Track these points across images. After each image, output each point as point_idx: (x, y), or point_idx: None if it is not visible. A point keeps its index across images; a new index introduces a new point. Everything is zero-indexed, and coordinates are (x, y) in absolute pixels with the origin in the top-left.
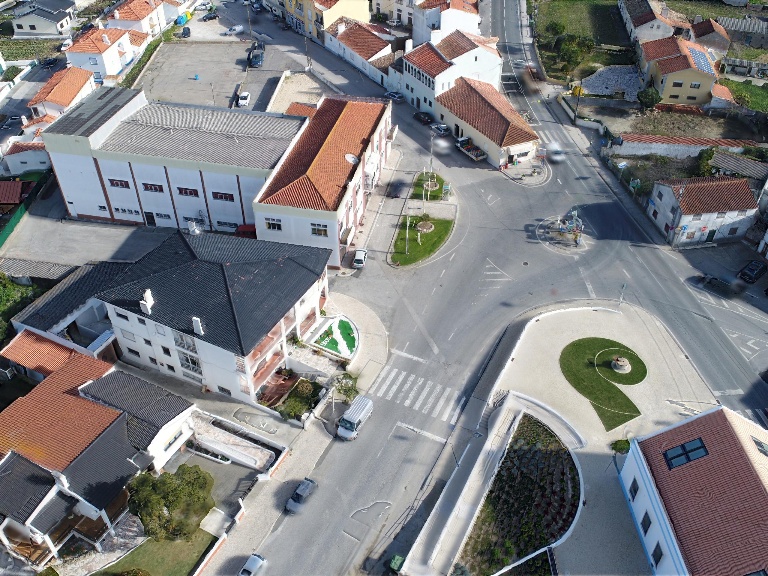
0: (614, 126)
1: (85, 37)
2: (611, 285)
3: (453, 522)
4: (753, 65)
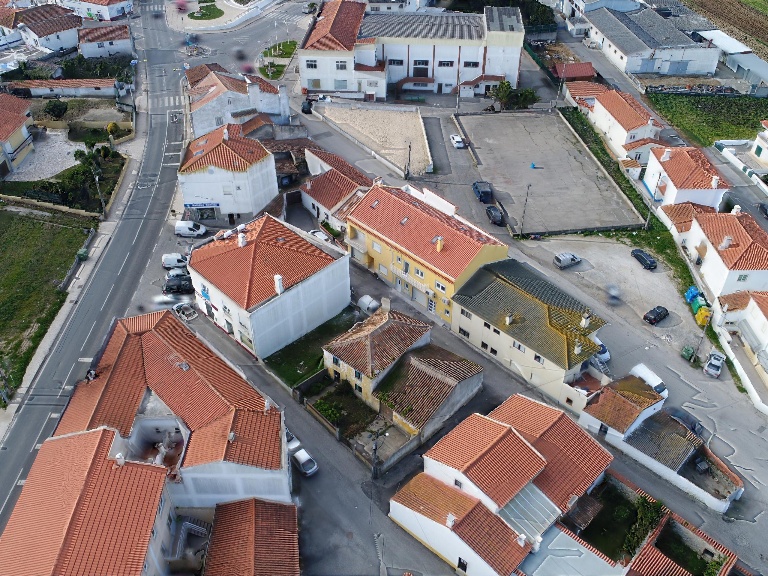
0: (102, 113)
1: (718, 176)
2: (183, 36)
3: None
4: None
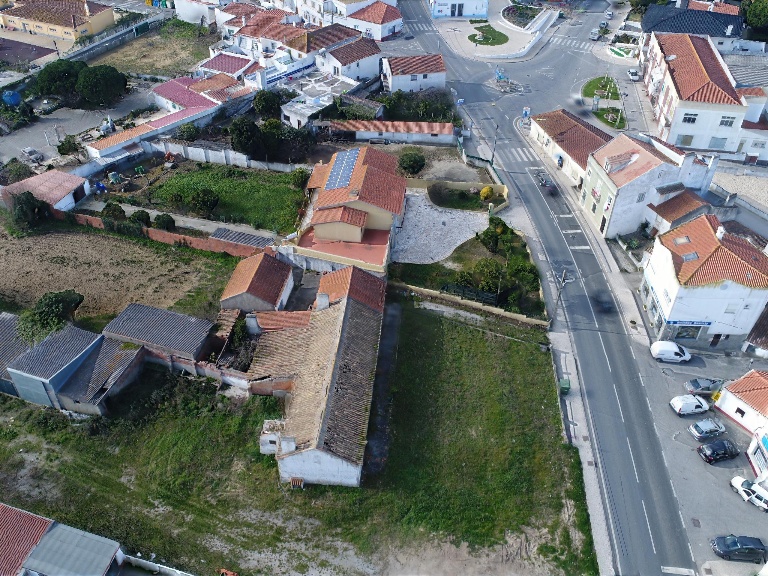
0: (450, 167)
1: None
2: (478, 65)
3: None
4: (236, 234)
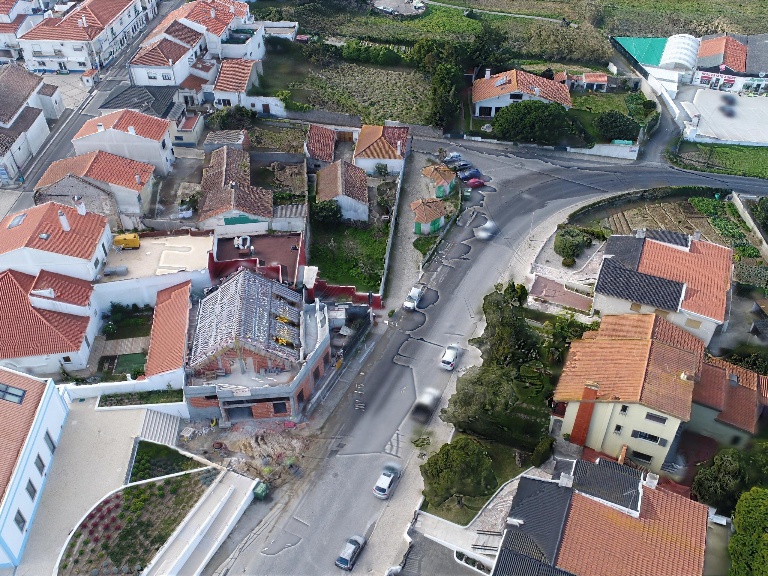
0: None
1: None
2: None
3: (204, 521)
4: None
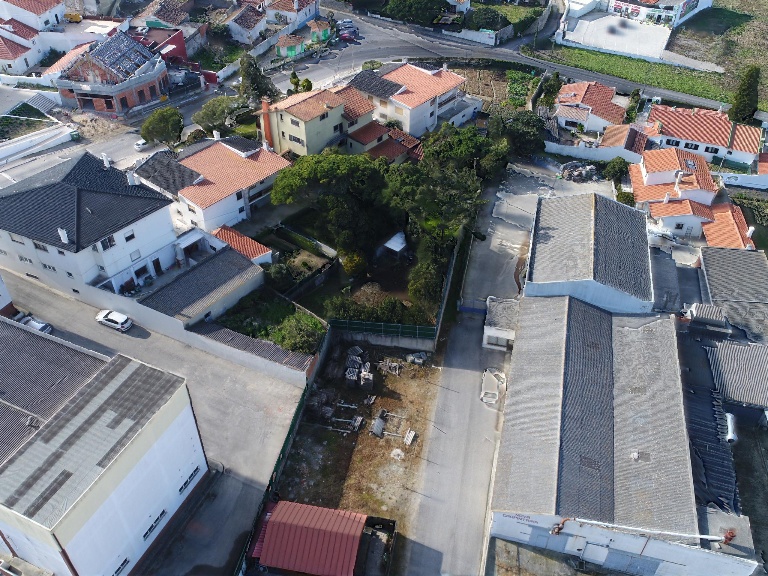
0: None
1: None
2: None
3: None
4: None
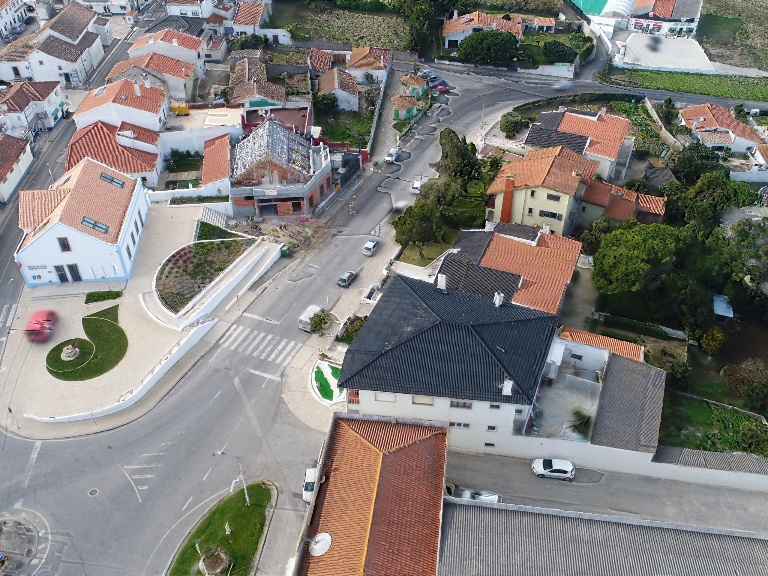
0: None
1: None
2: (7, 457)
3: None
4: None
